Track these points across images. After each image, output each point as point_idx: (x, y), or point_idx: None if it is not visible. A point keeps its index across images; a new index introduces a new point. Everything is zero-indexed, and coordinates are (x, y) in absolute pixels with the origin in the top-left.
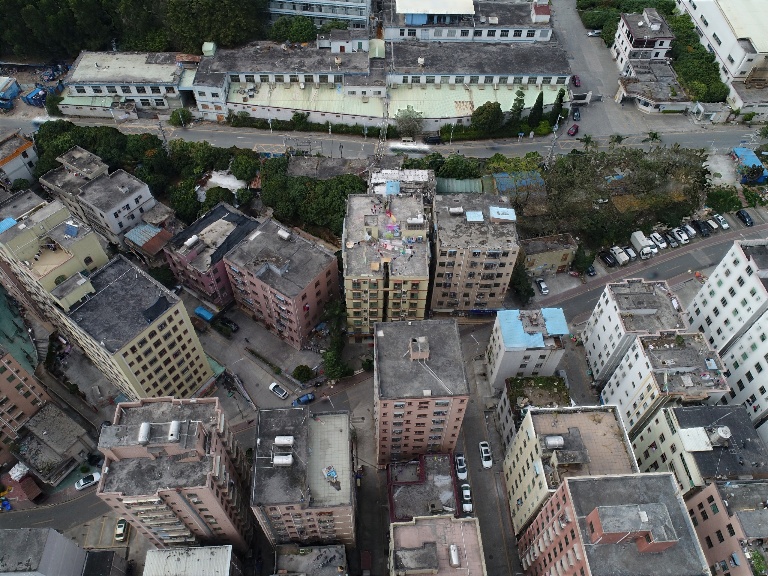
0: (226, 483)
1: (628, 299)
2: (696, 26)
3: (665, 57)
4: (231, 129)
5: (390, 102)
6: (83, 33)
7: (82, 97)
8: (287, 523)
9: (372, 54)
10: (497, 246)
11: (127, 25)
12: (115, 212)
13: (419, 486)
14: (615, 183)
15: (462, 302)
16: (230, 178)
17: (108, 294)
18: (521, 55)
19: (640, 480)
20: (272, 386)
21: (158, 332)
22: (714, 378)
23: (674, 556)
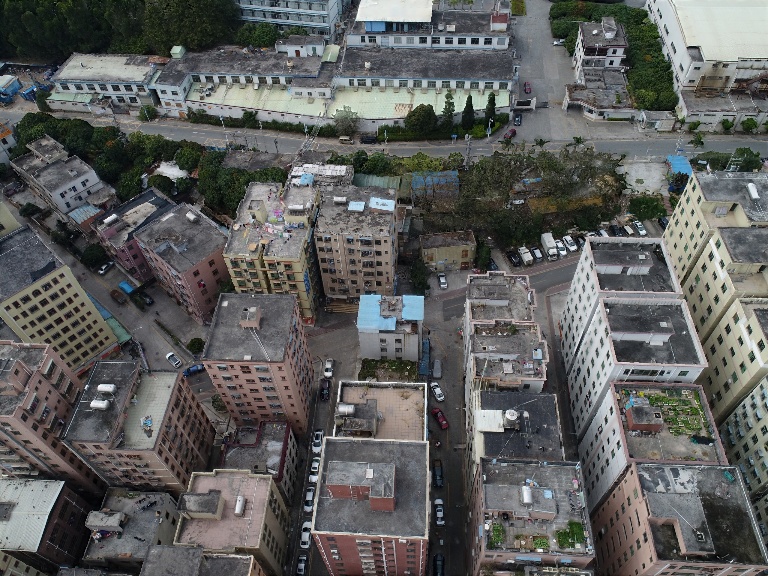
0: (50, 421)
1: (480, 289)
2: (660, 35)
3: (621, 65)
4: (190, 125)
5: (333, 103)
6: (77, 37)
7: (67, 93)
8: (108, 464)
9: (324, 58)
10: (369, 234)
11: (116, 31)
12: (61, 193)
13: (252, 449)
14: (533, 185)
15: (352, 289)
16: (176, 168)
17: (8, 257)
18: (468, 61)
19: (398, 446)
20: (168, 355)
21: (43, 292)
22: (533, 367)
23: (403, 516)
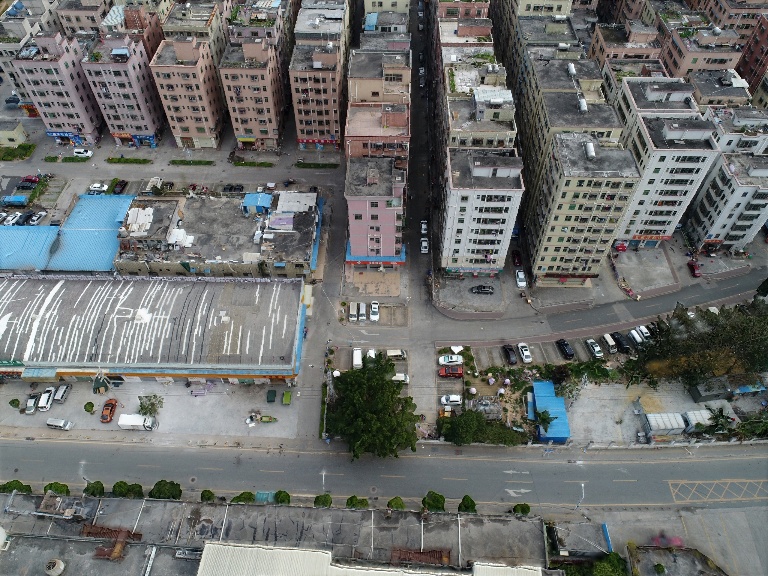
0: None
1: None
2: None
3: None
4: None
5: None
6: None
7: None
8: None
9: None
10: None
11: None
12: None
13: None
14: None
15: None
16: None
17: None
18: None
19: None
20: None
21: None
22: None
23: None
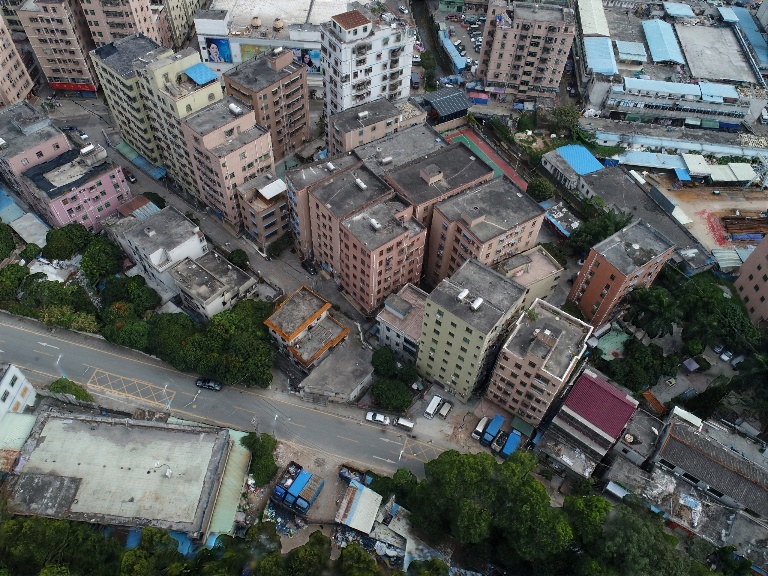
0: None
1: None
2: None
3: None
4: None
5: None
6: None
7: None
8: None
9: None
10: None
11: None
12: None
13: None
14: None
15: None
16: None
17: None
18: None
19: None
20: (85, 136)
21: None
22: None
23: None
